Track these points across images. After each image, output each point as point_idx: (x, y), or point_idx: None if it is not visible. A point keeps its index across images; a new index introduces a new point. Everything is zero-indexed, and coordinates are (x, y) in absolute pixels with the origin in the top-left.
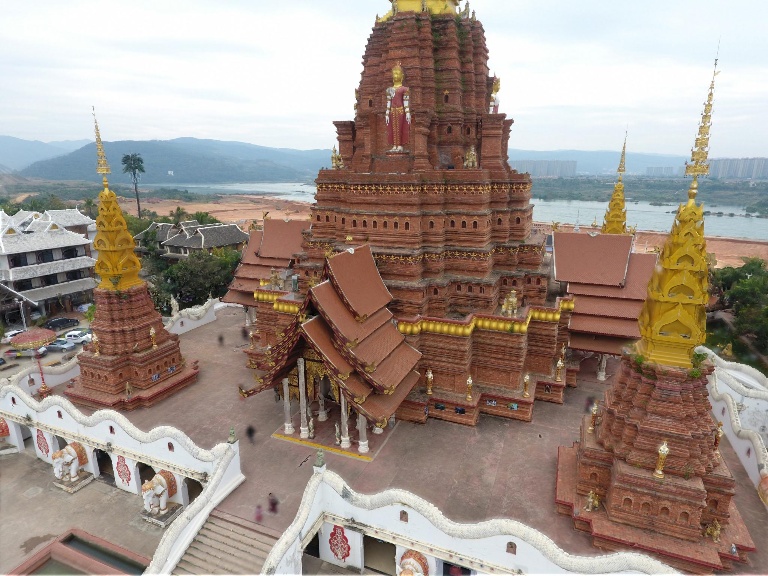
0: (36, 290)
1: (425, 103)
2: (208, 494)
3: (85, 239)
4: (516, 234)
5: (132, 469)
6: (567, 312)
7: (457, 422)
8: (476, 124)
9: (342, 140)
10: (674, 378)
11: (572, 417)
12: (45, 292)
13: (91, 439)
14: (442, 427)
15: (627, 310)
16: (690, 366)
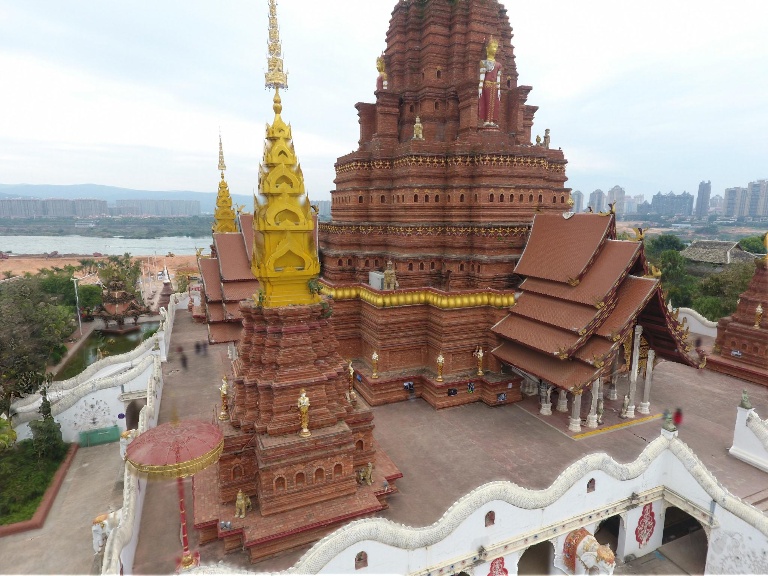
0: None
1: None
2: None
3: None
4: None
5: (515, 569)
6: None
7: None
8: None
9: (386, 113)
10: None
11: None
12: None
13: (440, 565)
14: None
15: None
16: None
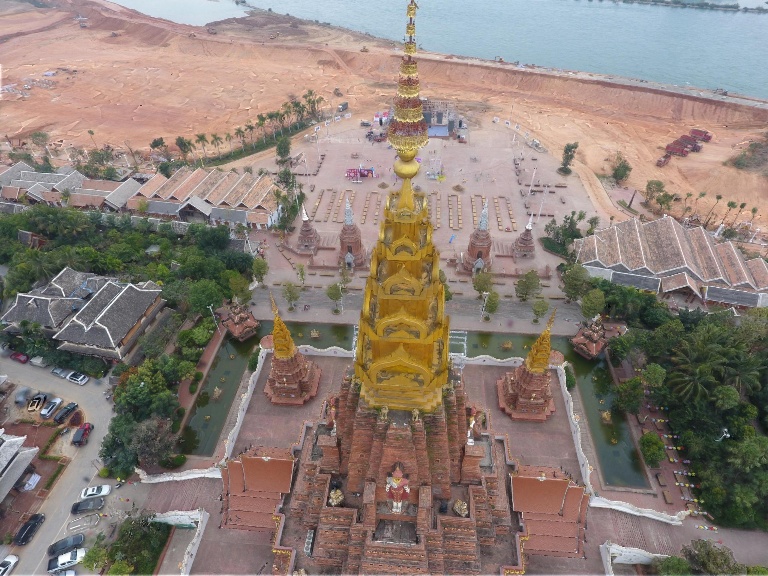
0: None
1: (420, 472)
2: None
3: None
4: None
5: None
6: None
7: None
8: None
9: None
10: None
11: None
12: None
13: None
14: None
15: (562, 529)
16: None
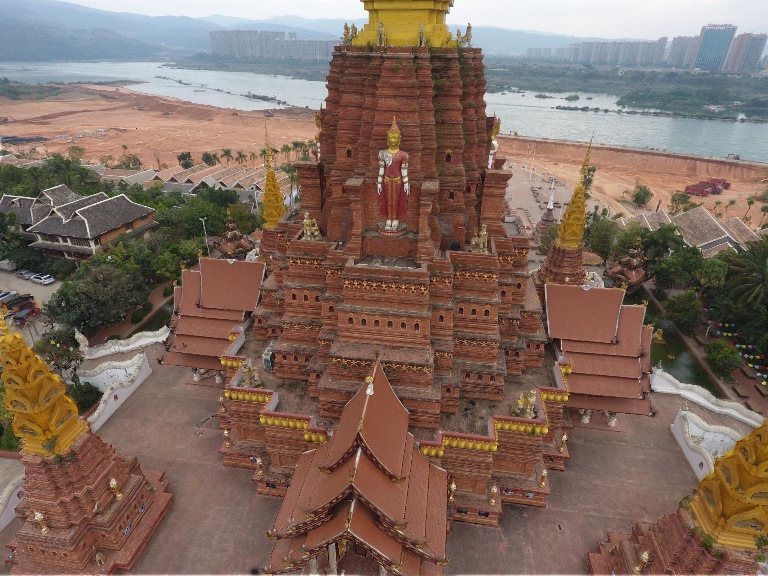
0: None
1: (424, 166)
2: None
3: None
4: (516, 299)
5: None
6: (564, 375)
7: (480, 523)
8: (478, 182)
9: (306, 185)
10: (742, 564)
11: (578, 489)
12: None
13: None
14: (468, 534)
15: (618, 368)
16: (755, 550)
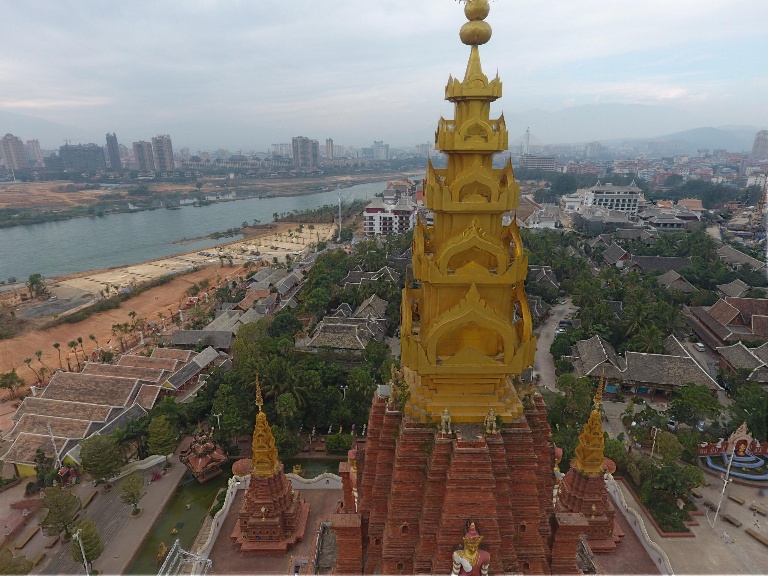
0: None
1: None
2: None
3: None
4: None
5: None
6: None
7: None
8: None
9: None
10: None
11: None
12: None
13: None
14: None
15: None
16: None
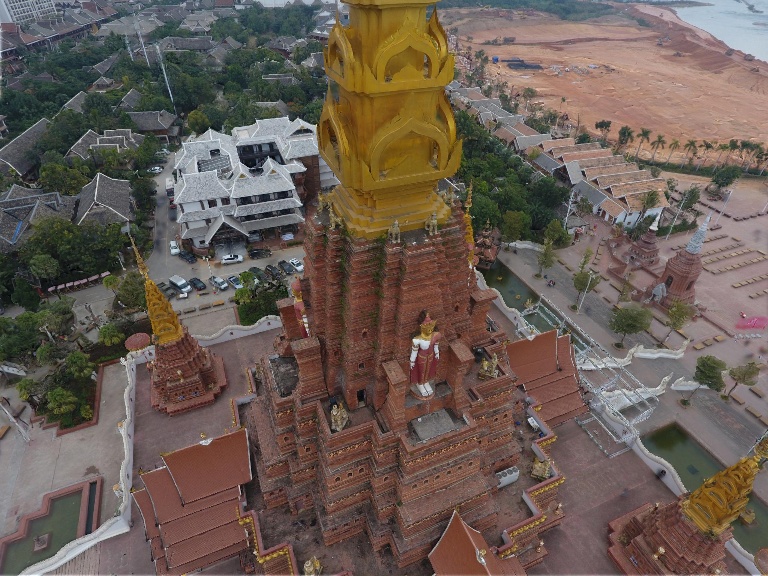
0: (254, 221)
1: None
2: (95, 535)
3: (291, 185)
4: None
5: None
6: None
7: None
8: (381, 366)
9: None
10: None
11: None
12: (259, 224)
13: None
14: None
15: None
16: None
